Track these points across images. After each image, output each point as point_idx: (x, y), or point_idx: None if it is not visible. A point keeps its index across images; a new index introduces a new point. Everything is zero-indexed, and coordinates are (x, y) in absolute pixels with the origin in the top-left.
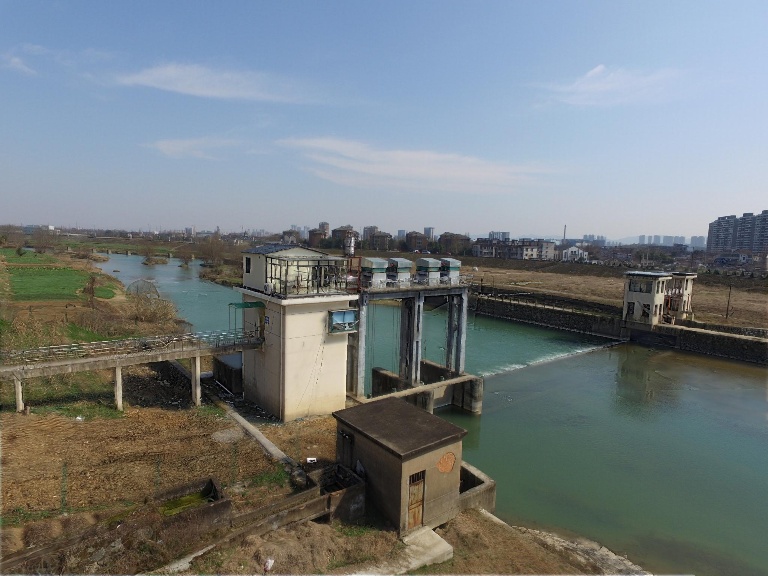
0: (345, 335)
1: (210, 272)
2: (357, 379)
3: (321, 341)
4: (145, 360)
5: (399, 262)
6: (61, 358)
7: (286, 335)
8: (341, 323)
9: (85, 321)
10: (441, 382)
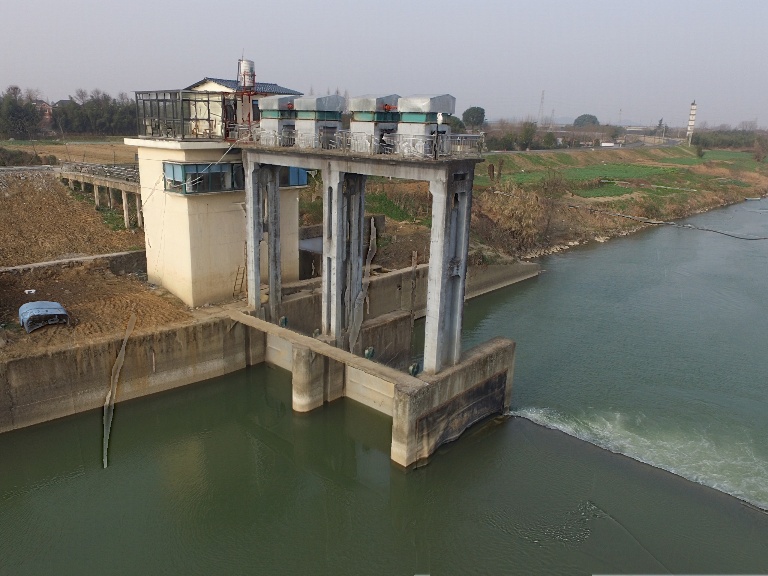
0: (184, 199)
1: None
2: (248, 280)
3: (166, 200)
4: None
5: (296, 100)
6: None
7: (141, 182)
8: None
9: (395, 194)
10: (345, 352)
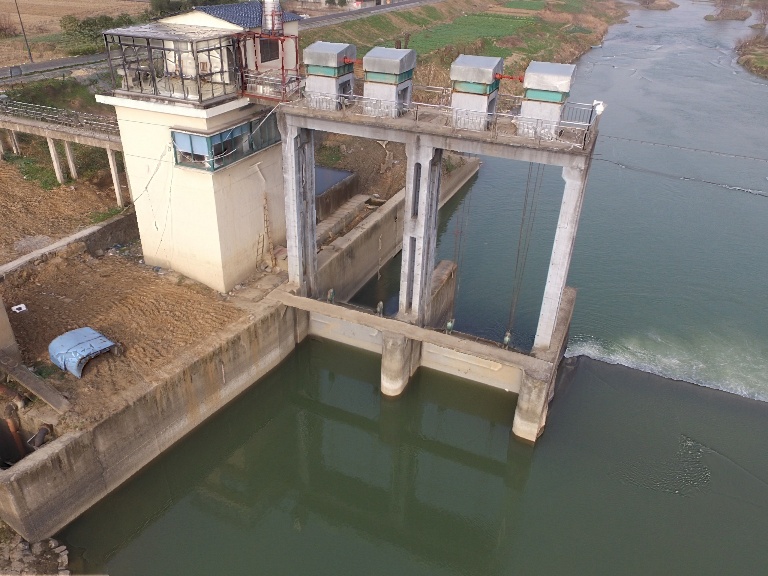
0: (206, 175)
1: (761, 42)
2: (288, 256)
3: (173, 172)
4: (66, 137)
5: (366, 58)
6: (25, 116)
7: (125, 148)
8: (189, 153)
9: None
10: (446, 336)
